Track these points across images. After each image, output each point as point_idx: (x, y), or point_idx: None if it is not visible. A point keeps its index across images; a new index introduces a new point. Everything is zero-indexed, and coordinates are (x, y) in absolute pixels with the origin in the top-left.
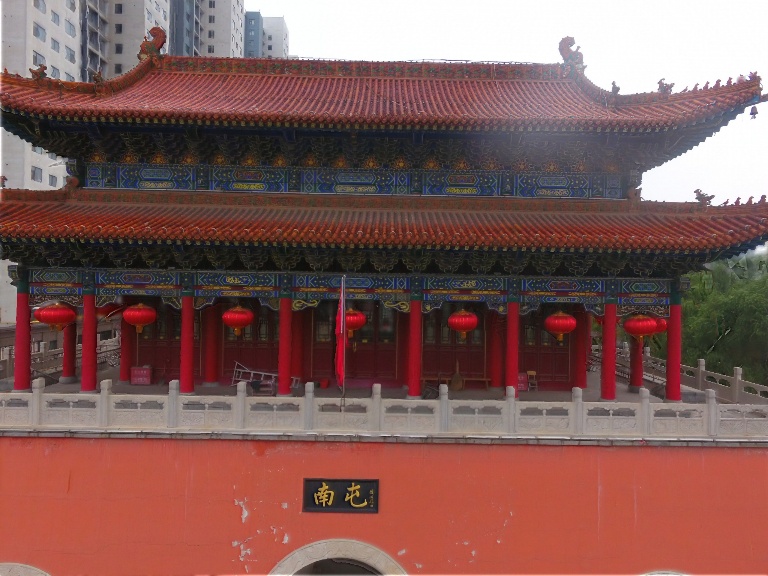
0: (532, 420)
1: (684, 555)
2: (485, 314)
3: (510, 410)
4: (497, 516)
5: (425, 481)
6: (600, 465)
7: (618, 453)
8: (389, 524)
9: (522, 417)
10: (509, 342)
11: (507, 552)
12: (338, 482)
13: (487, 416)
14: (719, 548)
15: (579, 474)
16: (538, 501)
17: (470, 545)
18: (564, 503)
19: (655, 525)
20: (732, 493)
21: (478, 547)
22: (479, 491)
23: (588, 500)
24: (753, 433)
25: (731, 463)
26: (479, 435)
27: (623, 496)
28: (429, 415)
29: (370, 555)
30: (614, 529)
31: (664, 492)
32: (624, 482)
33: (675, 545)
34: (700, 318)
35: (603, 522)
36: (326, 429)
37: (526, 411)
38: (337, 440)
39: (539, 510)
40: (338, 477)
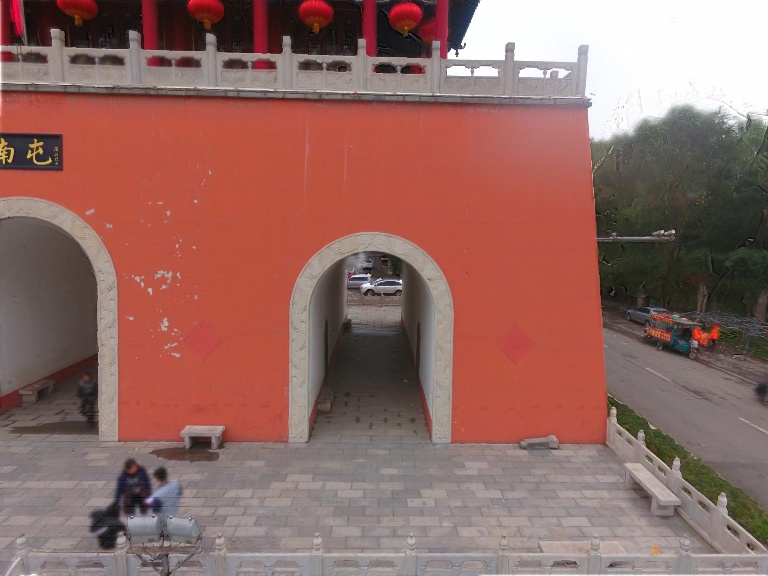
0: (236, 73)
1: (395, 217)
2: (231, 0)
3: (209, 60)
4: (195, 175)
5: (115, 137)
6: (309, 122)
7: (329, 109)
8: (76, 182)
9: (224, 70)
10: (255, 30)
11: (205, 212)
12: (18, 138)
13: (185, 68)
14: (433, 210)
15: (285, 132)
16: (240, 160)
17: (165, 205)
18: (268, 162)
19: (366, 186)
20: (451, 153)
21: (175, 208)
22: (175, 148)
23: (295, 159)
24: (481, 92)
25: (452, 121)
26: (172, 86)
27: (333, 155)
28: (119, 66)
29: (55, 214)
30: (321, 189)
31: (377, 151)
32: (335, 141)
33: (386, 207)
34: None
35: (310, 183)
36: (2, 80)
37: (229, 63)
38: (11, 89)
39: (240, 169)
40: (16, 131)
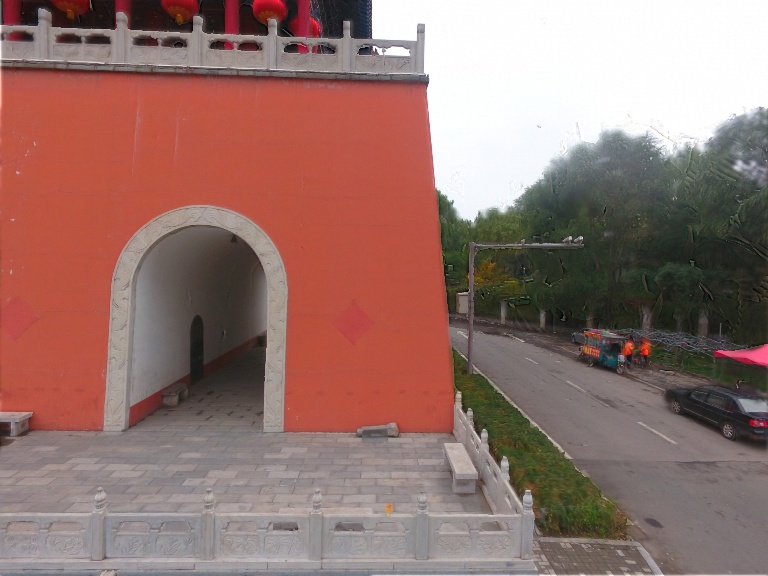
0: (68, 47)
1: (227, 190)
2: None
3: (40, 34)
4: (19, 146)
5: None
6: (140, 95)
7: (162, 83)
8: None
9: (57, 44)
10: None
11: (27, 184)
12: None
13: (17, 42)
14: (267, 183)
15: (116, 104)
16: (67, 132)
17: None
18: (96, 134)
19: (197, 158)
20: (286, 127)
21: None
22: None
23: (124, 132)
24: (319, 69)
25: (288, 96)
26: None
27: (164, 128)
28: None
29: None
30: (151, 162)
31: (210, 125)
32: (167, 114)
33: (218, 180)
34: (539, 180)
35: (140, 155)
36: None
37: (62, 38)
38: None
39: (67, 141)
40: None
